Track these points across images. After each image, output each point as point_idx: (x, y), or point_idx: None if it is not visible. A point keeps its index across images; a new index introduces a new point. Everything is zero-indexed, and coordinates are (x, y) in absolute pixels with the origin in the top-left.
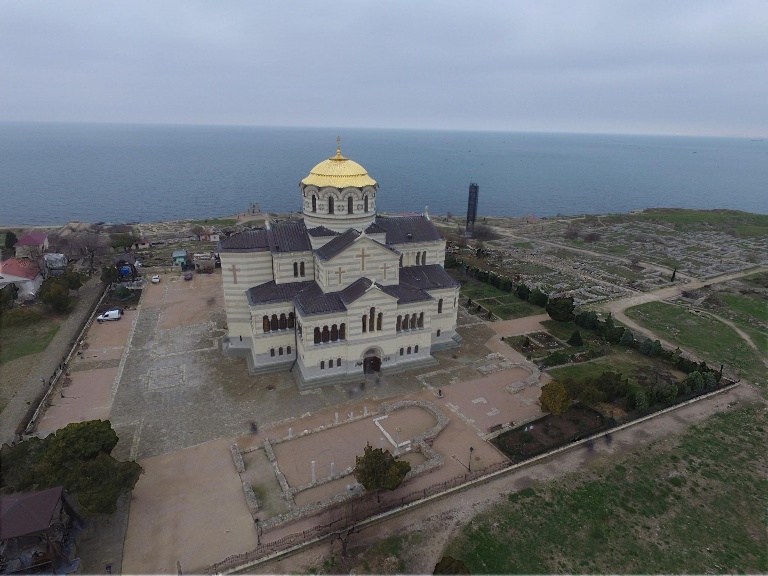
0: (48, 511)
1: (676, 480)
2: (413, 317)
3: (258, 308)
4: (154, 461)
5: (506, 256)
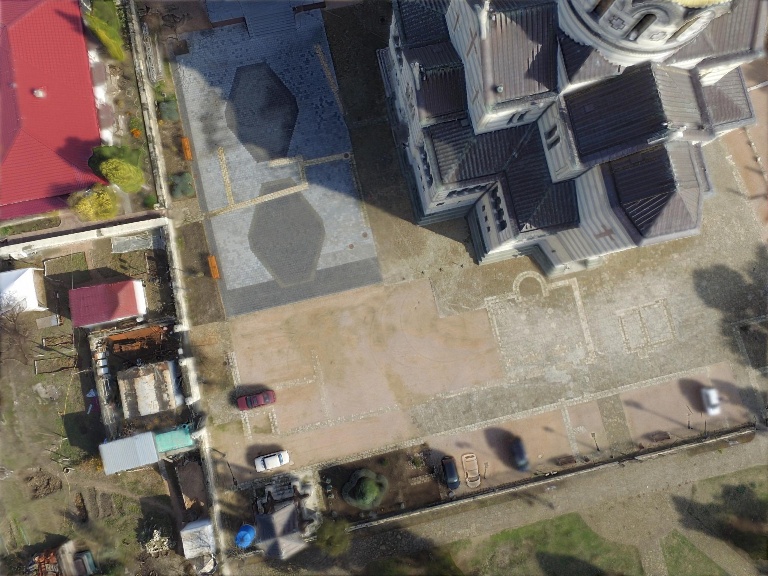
0: None
1: None
2: None
3: None
4: None
5: None
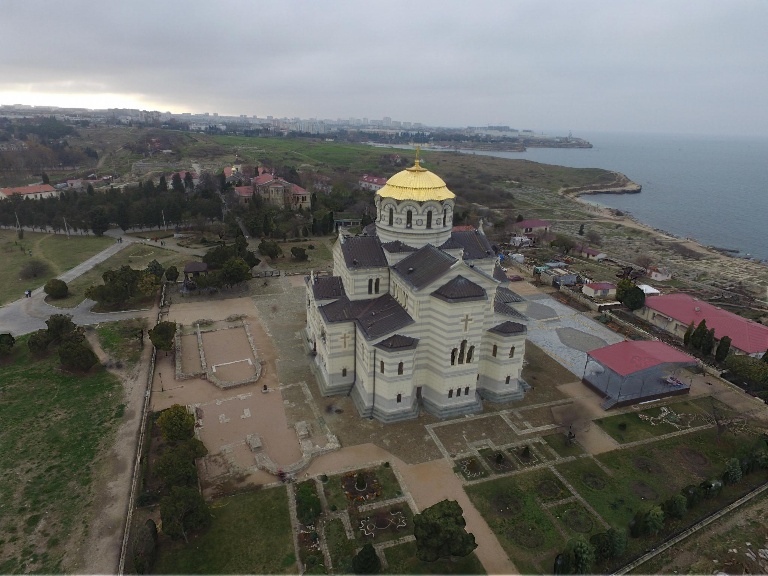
0: (192, 269)
1: (33, 520)
2: None
3: None
4: (248, 300)
5: None
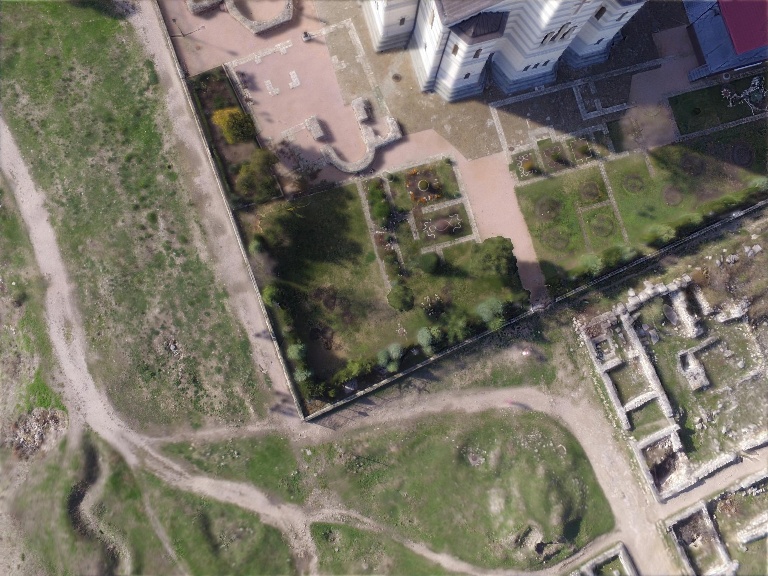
0: None
1: (152, 218)
2: None
3: None
4: None
5: None
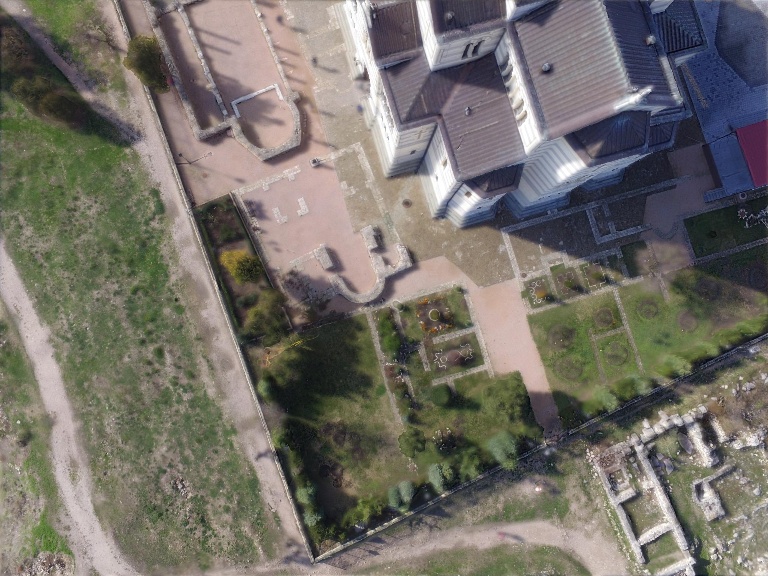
0: None
1: (159, 354)
2: None
3: None
4: None
5: None
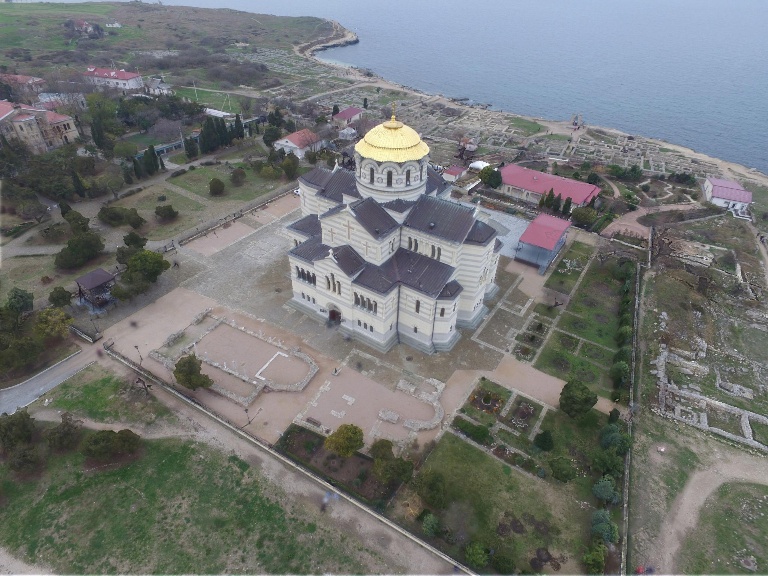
0: (97, 283)
1: None
2: (369, 300)
3: (291, 232)
4: (184, 291)
5: (767, 308)
